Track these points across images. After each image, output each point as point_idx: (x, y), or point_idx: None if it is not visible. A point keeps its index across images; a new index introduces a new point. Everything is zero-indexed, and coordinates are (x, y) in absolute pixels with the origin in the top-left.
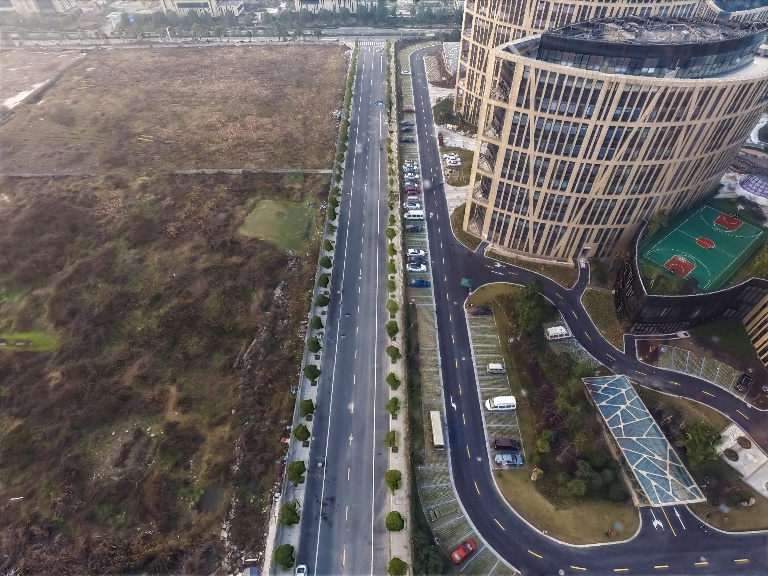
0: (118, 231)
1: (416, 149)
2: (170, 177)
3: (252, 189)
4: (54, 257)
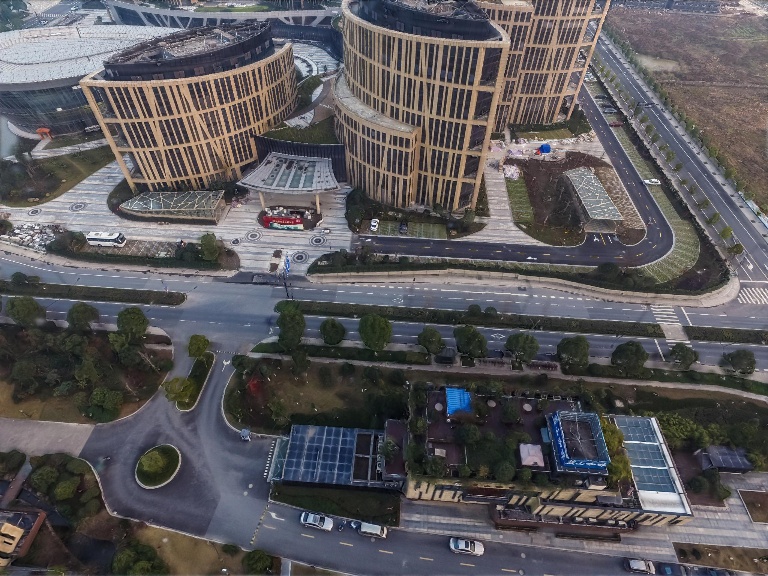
0: (746, 59)
1: (591, 93)
2: (767, 85)
3: (694, 74)
4: (761, 53)
